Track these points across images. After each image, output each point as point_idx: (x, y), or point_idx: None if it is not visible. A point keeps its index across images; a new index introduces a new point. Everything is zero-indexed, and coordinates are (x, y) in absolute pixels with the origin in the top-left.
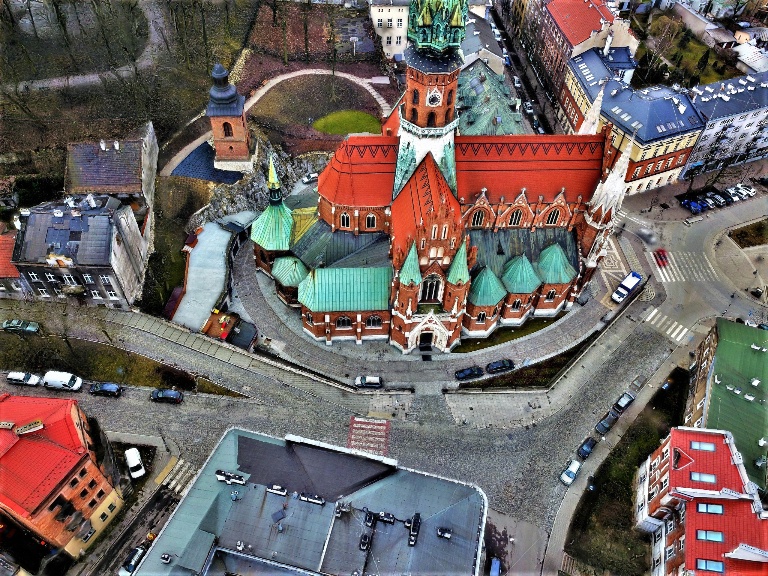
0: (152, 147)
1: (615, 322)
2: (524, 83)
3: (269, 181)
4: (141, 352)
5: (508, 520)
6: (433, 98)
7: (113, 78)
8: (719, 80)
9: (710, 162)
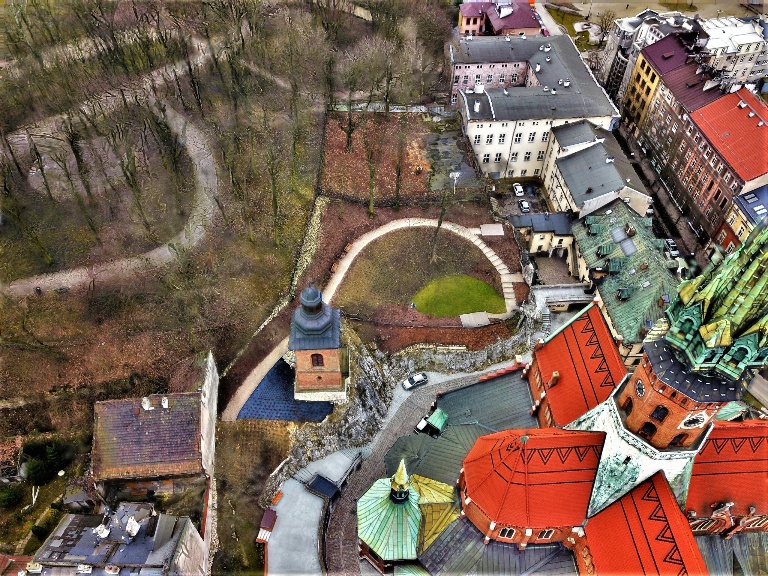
0: (211, 386)
1: None
2: (656, 207)
3: (395, 481)
4: None
5: None
6: (692, 420)
7: (153, 265)
8: None
9: None
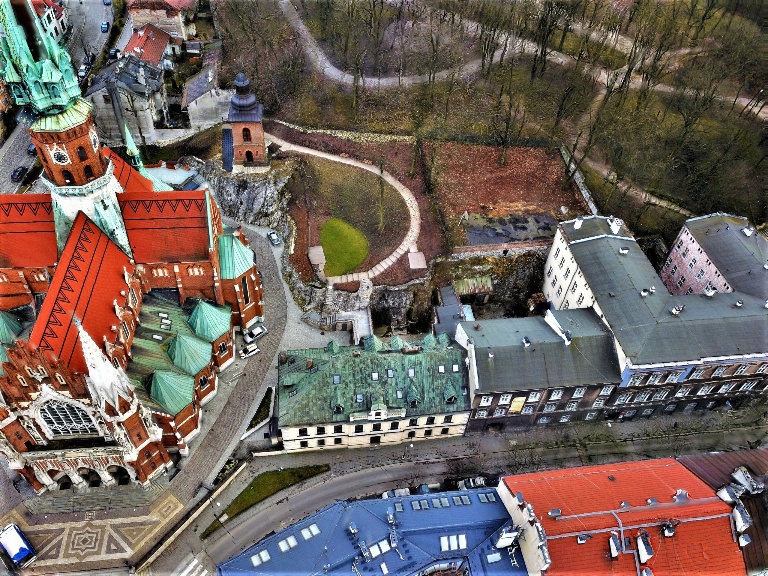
0: None
1: None
2: None
3: None
4: None
5: None
6: None
7: None
8: None
9: None
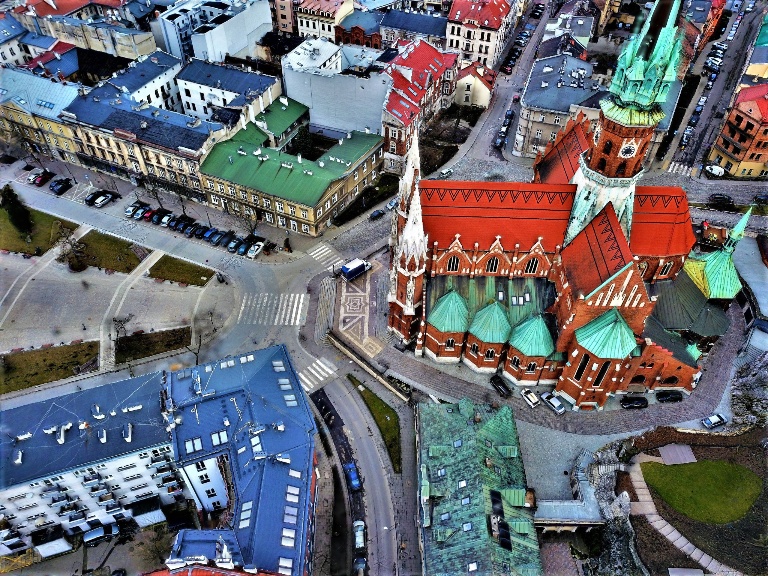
0: None
1: None
2: None
3: None
4: (761, 217)
5: (488, 159)
6: None
7: None
8: None
9: None
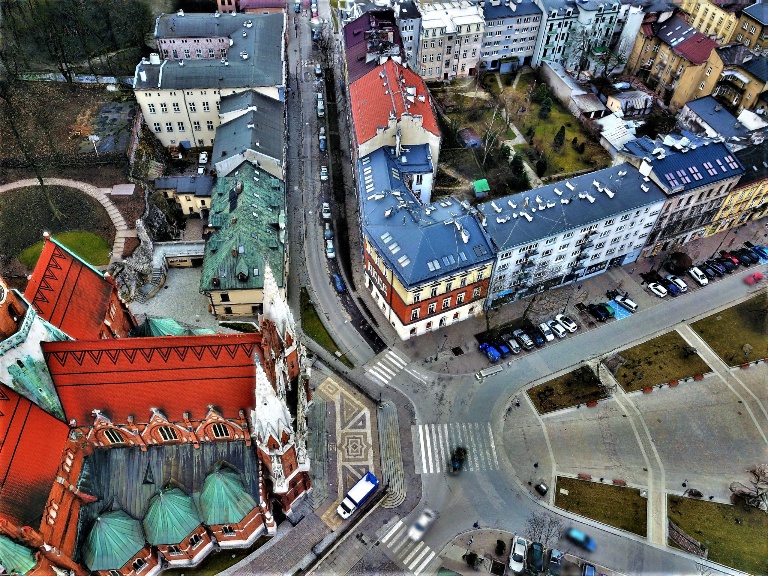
0: None
1: (337, 547)
2: (333, 174)
3: None
4: None
5: None
6: None
7: None
8: (576, 161)
9: (520, 290)
